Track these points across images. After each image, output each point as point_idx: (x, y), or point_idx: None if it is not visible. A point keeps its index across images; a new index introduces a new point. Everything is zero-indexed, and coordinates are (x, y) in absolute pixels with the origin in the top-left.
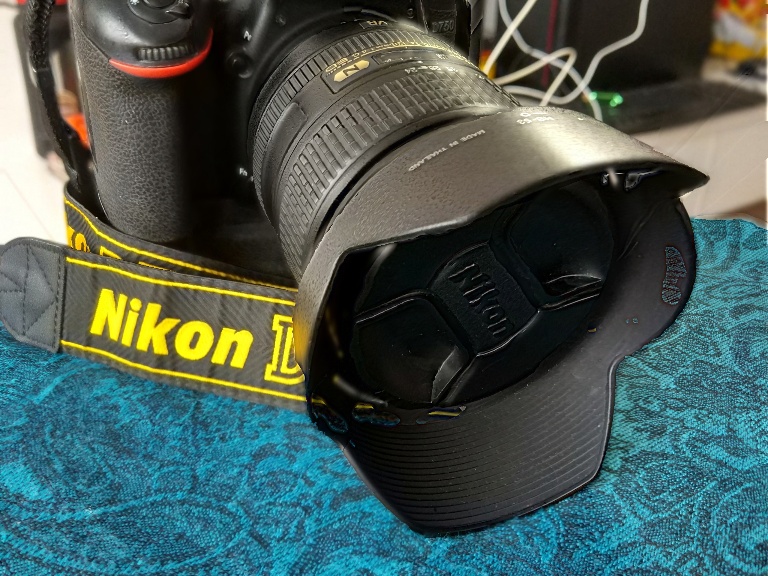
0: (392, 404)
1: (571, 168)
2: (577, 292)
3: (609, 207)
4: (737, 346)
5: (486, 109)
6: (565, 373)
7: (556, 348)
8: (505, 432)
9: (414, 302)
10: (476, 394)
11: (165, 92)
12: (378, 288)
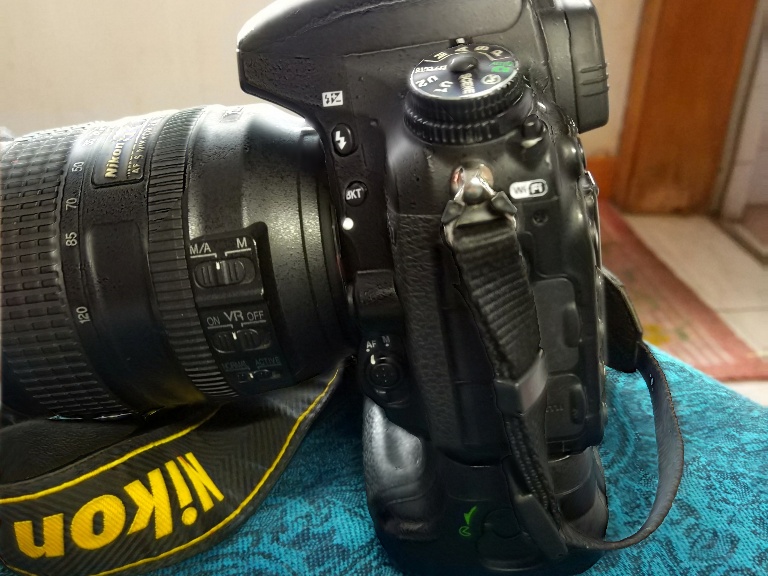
0: None
1: None
2: None
3: None
4: None
5: (4, 153)
6: None
7: None
8: None
9: None
10: None
11: None
12: None
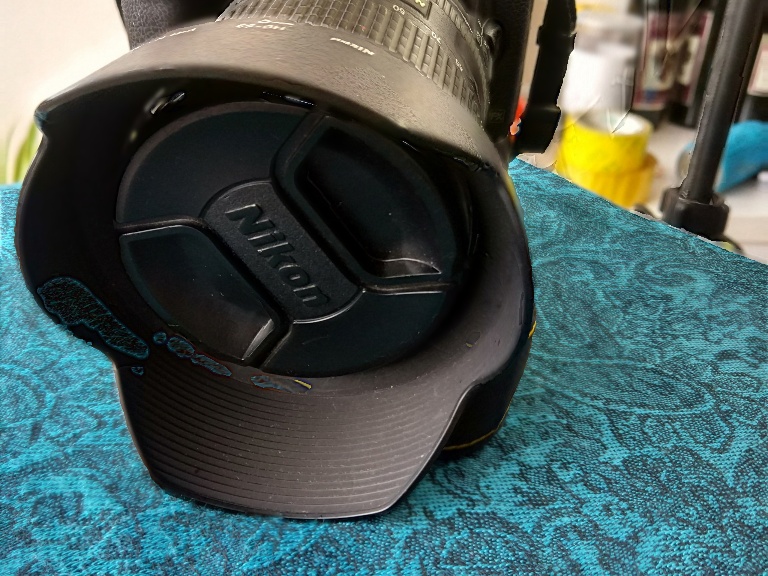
0: (197, 346)
1: (165, 64)
2: (410, 280)
3: (431, 176)
4: (761, 450)
5: None
6: (429, 385)
7: (411, 349)
8: (339, 427)
9: (184, 229)
10: (303, 370)
11: None
12: (134, 200)
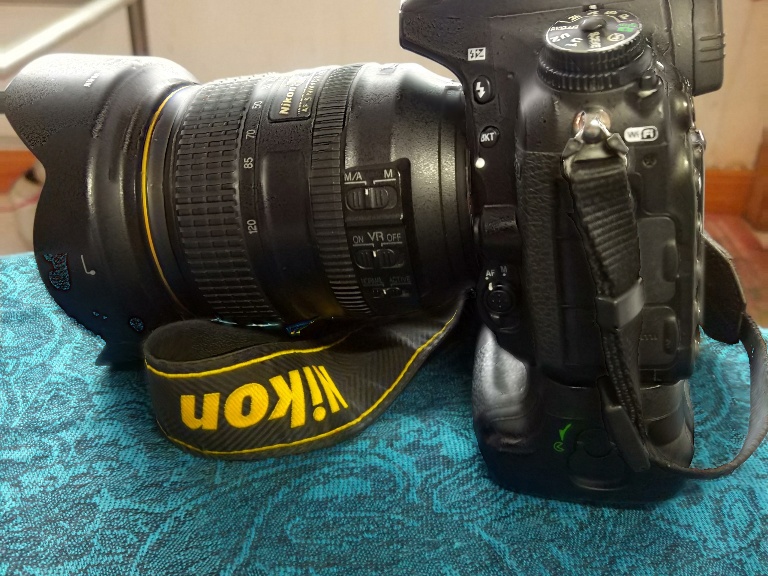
0: None
1: None
2: None
3: None
4: None
5: None
6: None
7: None
8: None
9: None
10: None
11: None
12: None
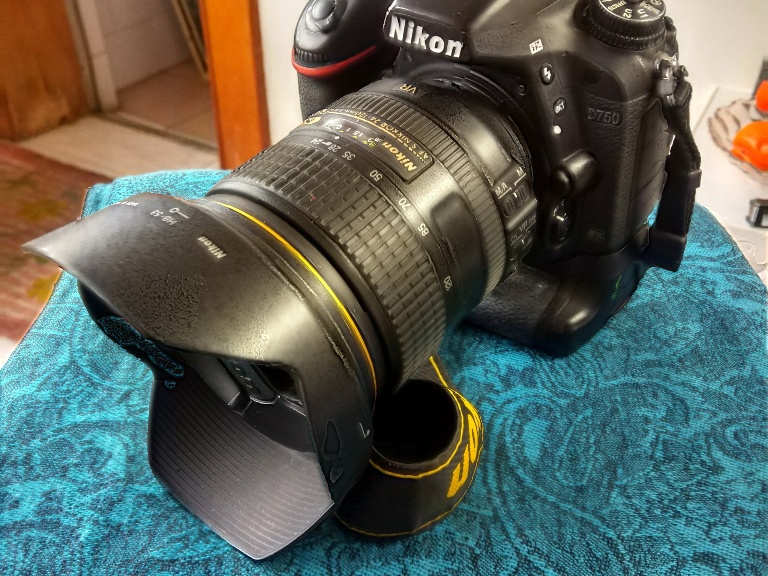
0: None
1: None
2: None
3: None
4: None
5: (280, 200)
6: None
7: None
8: (282, 480)
9: None
10: (262, 429)
11: (319, 84)
12: None
